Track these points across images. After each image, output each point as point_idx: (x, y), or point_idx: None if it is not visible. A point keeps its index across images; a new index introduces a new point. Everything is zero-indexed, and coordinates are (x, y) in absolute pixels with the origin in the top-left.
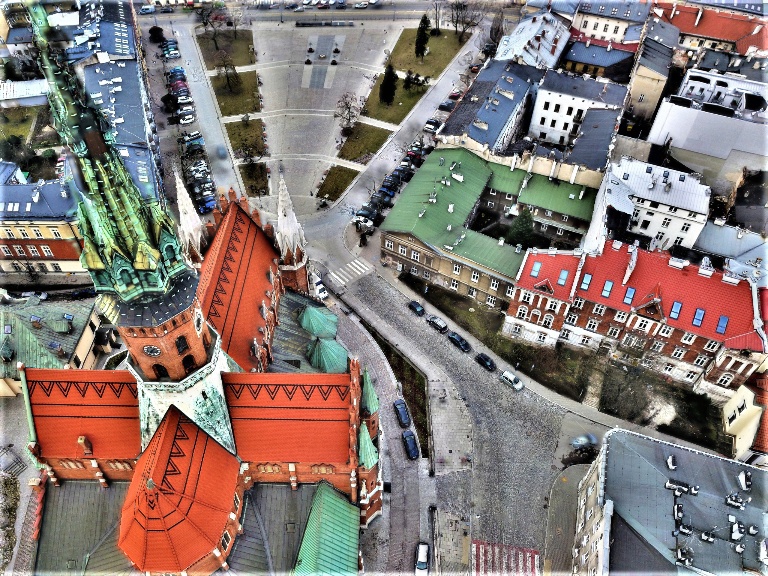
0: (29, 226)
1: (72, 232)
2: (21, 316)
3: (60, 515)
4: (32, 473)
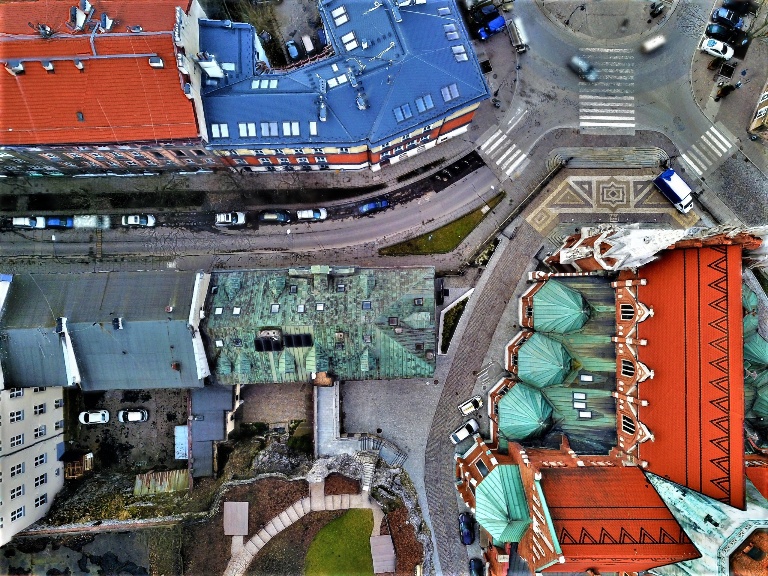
0: (311, 148)
1: (366, 147)
2: (380, 324)
3: (522, 570)
4: (416, 462)
